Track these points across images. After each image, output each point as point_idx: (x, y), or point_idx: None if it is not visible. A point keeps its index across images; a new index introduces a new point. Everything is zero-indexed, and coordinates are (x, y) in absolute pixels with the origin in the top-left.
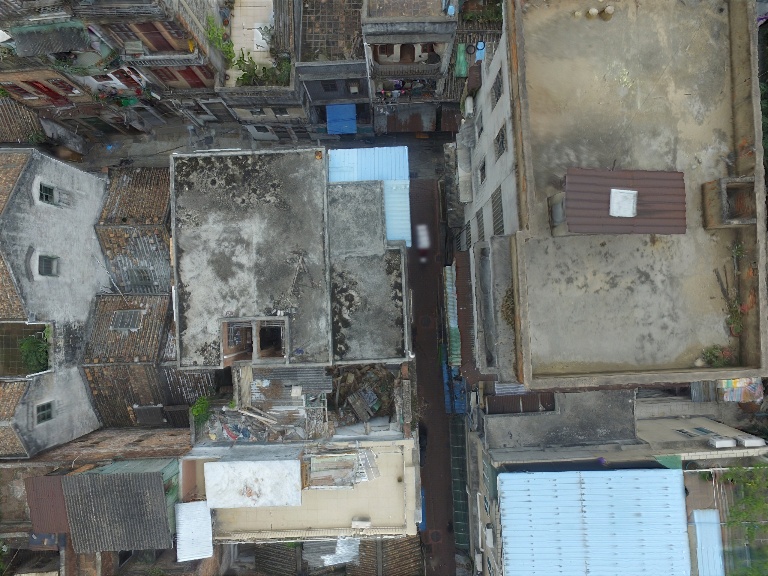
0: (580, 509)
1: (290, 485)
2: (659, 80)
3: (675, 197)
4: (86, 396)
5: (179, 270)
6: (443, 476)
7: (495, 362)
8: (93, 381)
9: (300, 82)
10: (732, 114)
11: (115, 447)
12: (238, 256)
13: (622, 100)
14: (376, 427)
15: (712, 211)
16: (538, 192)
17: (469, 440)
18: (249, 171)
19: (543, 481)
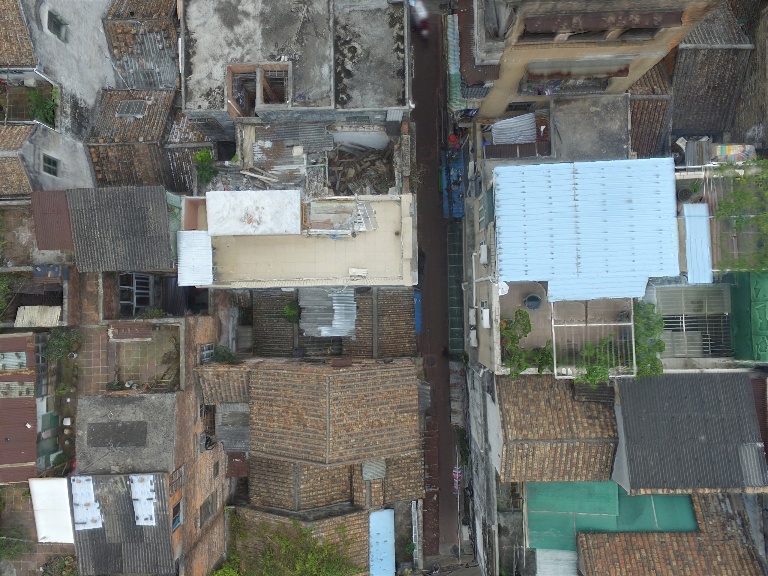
0: (573, 198)
1: (290, 214)
2: None
3: None
4: (91, 178)
5: (186, 18)
6: (439, 302)
7: (494, 39)
8: (98, 164)
9: None
10: None
11: None
12: (244, 5)
13: None
14: None
15: None
16: None
17: (466, 205)
18: None
19: (537, 173)
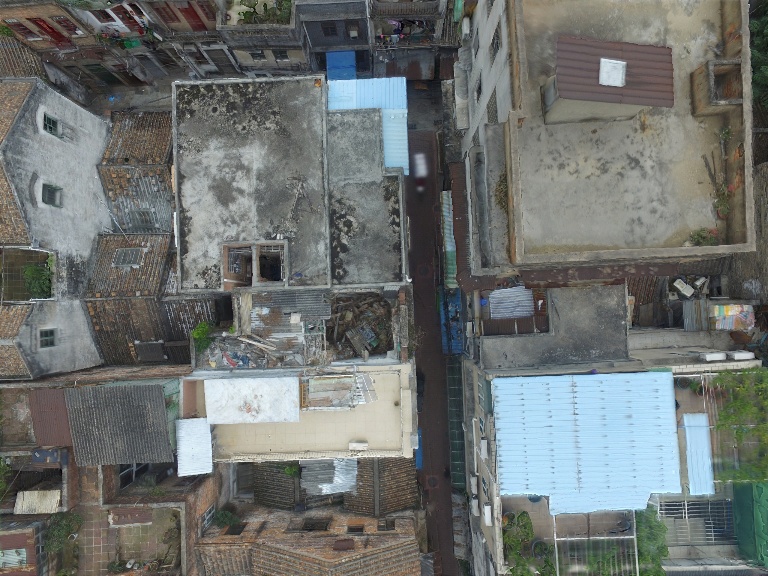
0: (572, 412)
1: (289, 401)
2: None
3: (663, 71)
4: (88, 331)
5: (180, 195)
6: (440, 422)
7: (489, 264)
8: (95, 316)
9: (300, 23)
10: (720, 5)
11: (117, 374)
12: (239, 182)
13: None
14: None
15: (700, 95)
16: (531, 81)
17: (465, 368)
18: (250, 99)
19: (536, 385)
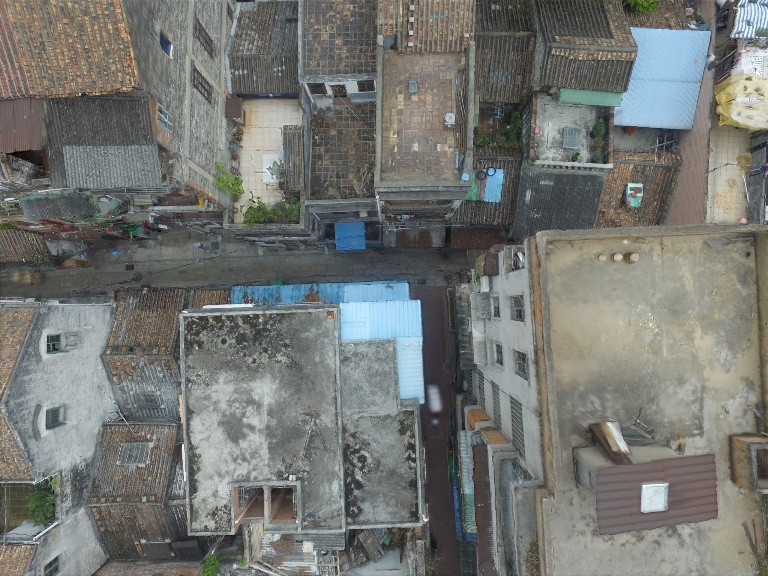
0: None
1: None
2: (685, 325)
3: (706, 482)
4: (93, 534)
5: (189, 432)
6: None
7: None
8: (100, 519)
9: (309, 214)
10: (760, 363)
11: None
12: (249, 417)
13: (648, 346)
14: (388, 571)
15: (741, 471)
16: (562, 441)
17: None
18: (260, 330)
19: None
